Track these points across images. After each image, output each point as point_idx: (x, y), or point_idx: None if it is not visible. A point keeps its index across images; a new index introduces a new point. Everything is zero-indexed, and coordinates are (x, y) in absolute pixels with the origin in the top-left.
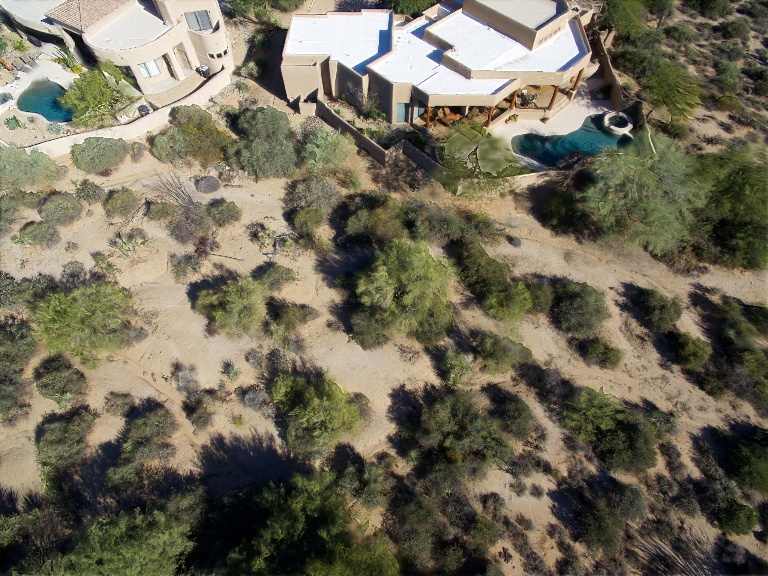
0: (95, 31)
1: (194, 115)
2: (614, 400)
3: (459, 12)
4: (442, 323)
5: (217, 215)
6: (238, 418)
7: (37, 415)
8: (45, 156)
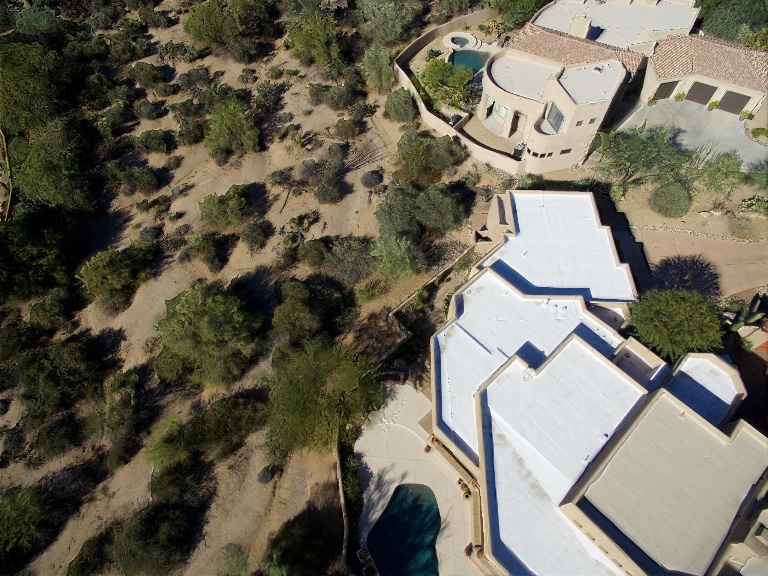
0: (518, 56)
1: (440, 148)
2: (13, 542)
3: (641, 389)
4: (164, 369)
5: (320, 184)
6: (139, 226)
7: (178, 127)
8: (391, 76)
